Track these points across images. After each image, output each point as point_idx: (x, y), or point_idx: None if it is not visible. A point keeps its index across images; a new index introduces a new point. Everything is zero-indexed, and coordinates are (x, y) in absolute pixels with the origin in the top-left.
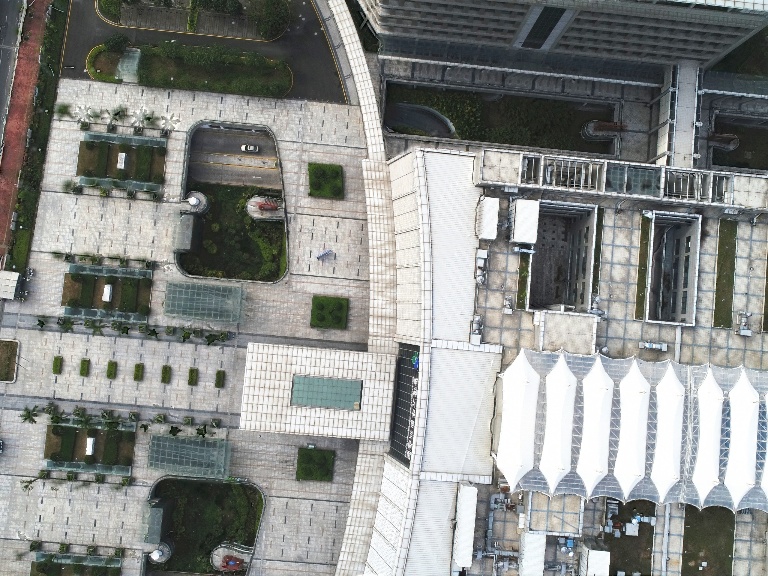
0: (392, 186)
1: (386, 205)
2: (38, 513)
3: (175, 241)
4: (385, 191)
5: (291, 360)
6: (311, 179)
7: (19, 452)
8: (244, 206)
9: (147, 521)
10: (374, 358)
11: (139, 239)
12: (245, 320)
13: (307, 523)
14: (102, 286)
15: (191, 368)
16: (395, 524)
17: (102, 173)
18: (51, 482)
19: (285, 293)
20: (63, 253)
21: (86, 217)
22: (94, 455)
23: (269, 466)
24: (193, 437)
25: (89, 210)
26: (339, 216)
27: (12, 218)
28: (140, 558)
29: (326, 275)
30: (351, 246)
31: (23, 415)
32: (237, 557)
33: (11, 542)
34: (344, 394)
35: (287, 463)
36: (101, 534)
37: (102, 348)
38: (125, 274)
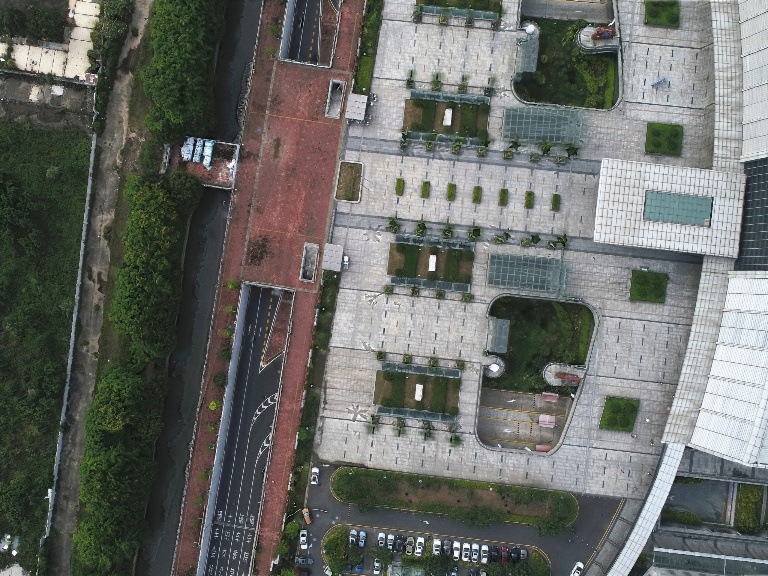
0: (740, 8)
1: (733, 28)
2: (382, 326)
3: (519, 65)
4: (732, 14)
5: (644, 176)
6: (648, 7)
7: (364, 268)
8: (573, 37)
9: (493, 332)
10: (724, 176)
11: (477, 66)
12: (580, 146)
13: (639, 343)
14: (442, 111)
15: (528, 191)
16: (762, 328)
17: (442, 1)
18: (394, 297)
19: (619, 120)
20: (403, 80)
21: (425, 45)
22: (436, 272)
23: (602, 287)
24: (533, 256)
25: (428, 38)
26: (673, 45)
27: (359, 44)
28: (478, 371)
29: (660, 103)
30: (685, 74)
31: (390, 222)
32: (571, 373)
33: (357, 352)
34: (695, 210)
35: (620, 285)
36: (441, 347)
37: (441, 171)
38: (464, 100)
